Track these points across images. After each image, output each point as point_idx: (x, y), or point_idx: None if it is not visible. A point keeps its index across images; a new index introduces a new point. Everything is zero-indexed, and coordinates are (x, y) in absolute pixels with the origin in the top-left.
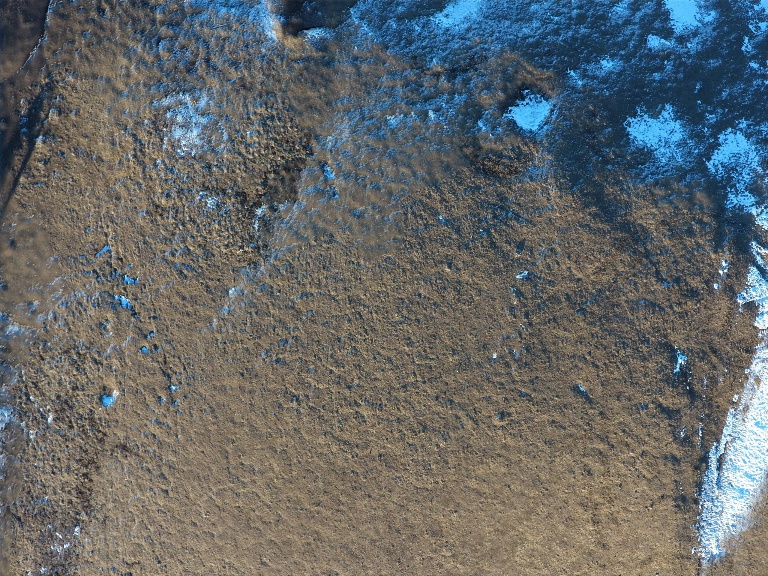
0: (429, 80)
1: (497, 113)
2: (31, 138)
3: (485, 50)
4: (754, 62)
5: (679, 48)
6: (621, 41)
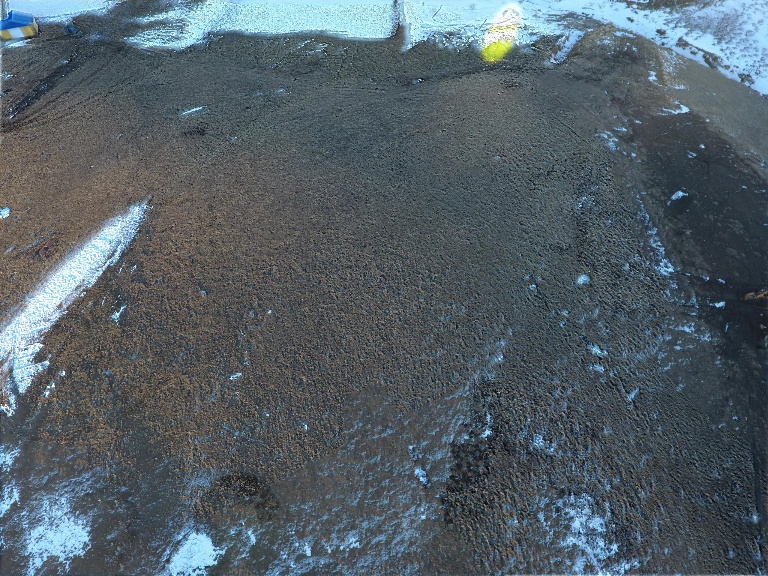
0: None
1: (232, 554)
2: (766, 516)
3: None
4: None
5: None
6: None
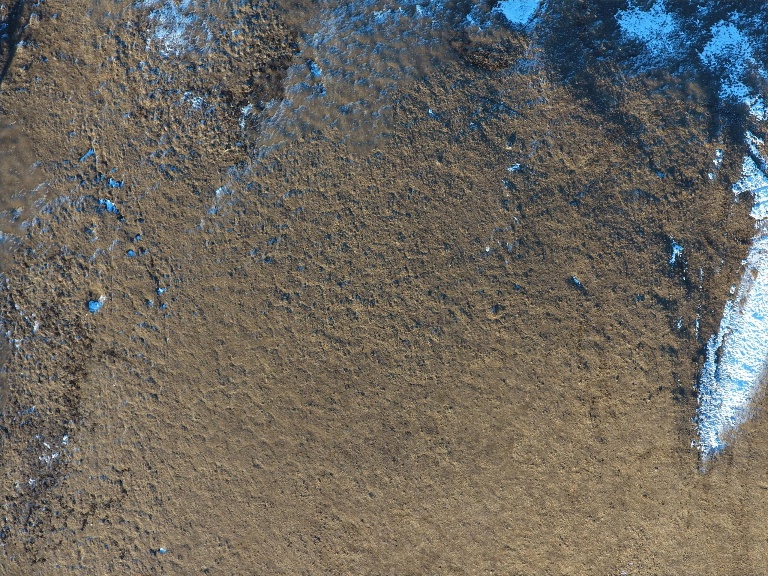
0: None
1: (486, 7)
2: (12, 44)
3: None
4: None
5: None
6: None
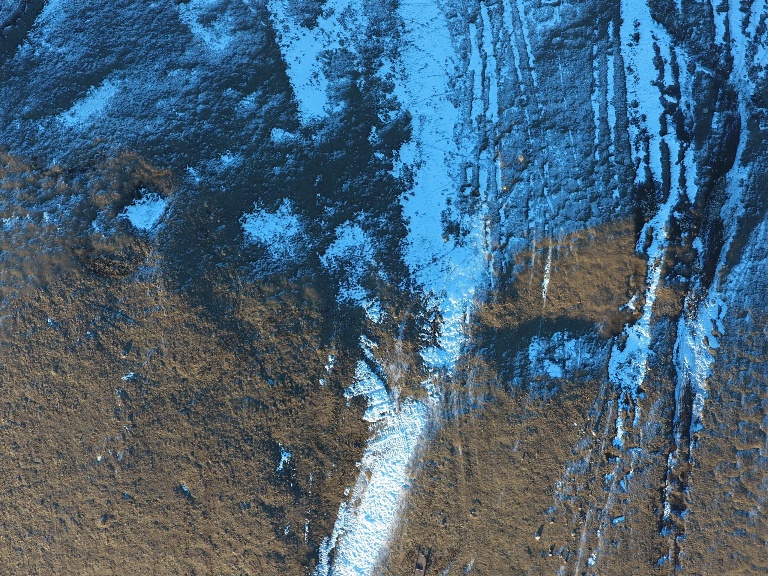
0: (47, 181)
1: (111, 213)
2: None
3: (105, 149)
4: (379, 152)
5: (303, 140)
6: (244, 136)
